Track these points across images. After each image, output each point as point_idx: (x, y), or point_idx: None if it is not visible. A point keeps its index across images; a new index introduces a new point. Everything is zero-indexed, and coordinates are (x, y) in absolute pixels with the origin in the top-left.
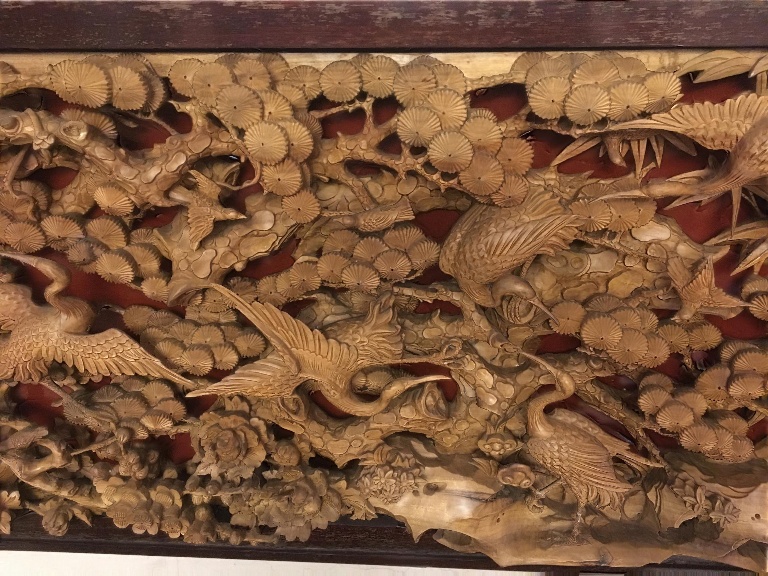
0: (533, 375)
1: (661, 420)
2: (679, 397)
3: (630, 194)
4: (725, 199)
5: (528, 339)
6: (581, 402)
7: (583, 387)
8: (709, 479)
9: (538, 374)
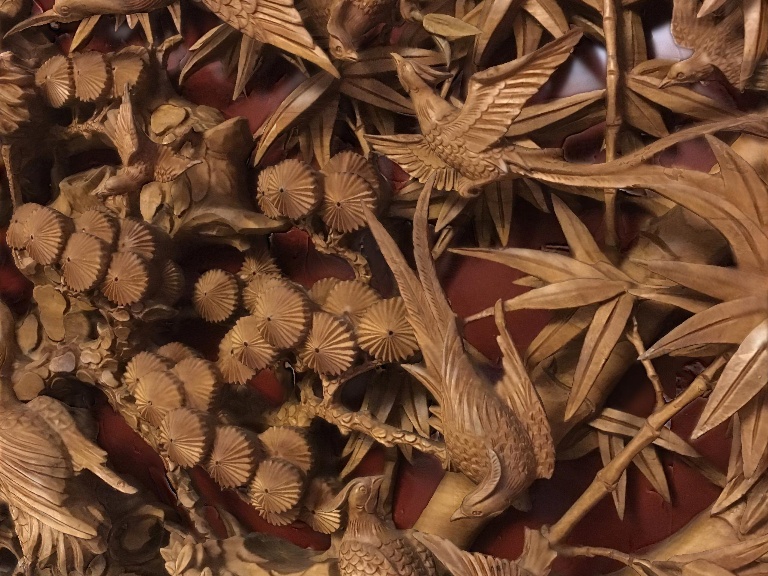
0: (45, 358)
1: (137, 402)
2: (174, 367)
3: (42, 16)
4: (275, 72)
5: (67, 314)
6: (108, 411)
7: (100, 377)
8: (256, 561)
9: (53, 357)
